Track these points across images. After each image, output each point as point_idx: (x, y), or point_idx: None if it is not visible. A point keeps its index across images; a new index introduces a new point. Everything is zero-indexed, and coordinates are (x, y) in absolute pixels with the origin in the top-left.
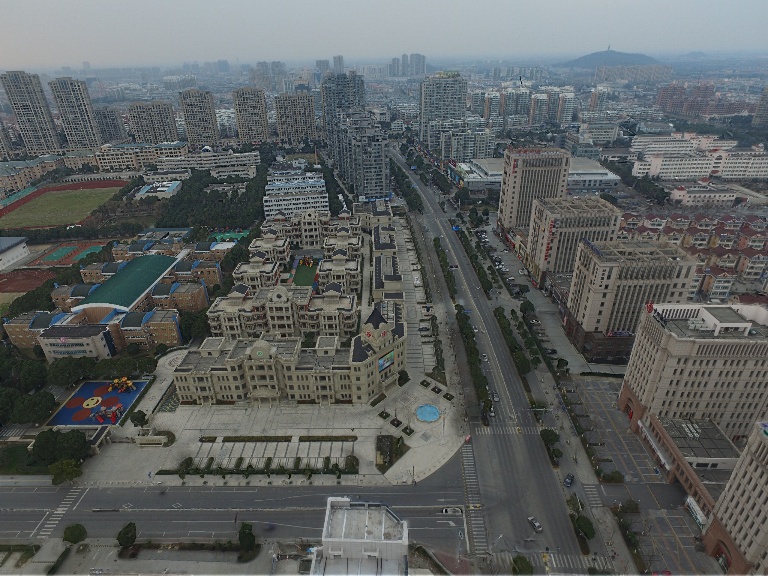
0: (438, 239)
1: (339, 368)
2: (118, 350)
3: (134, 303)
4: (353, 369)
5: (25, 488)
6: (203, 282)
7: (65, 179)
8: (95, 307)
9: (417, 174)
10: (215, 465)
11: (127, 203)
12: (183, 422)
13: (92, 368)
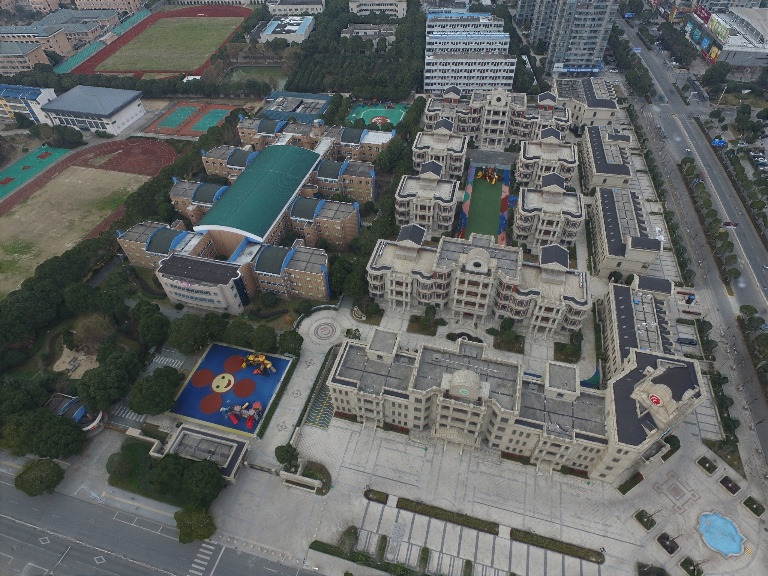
0: (692, 161)
1: (587, 437)
2: (250, 295)
3: (270, 229)
4: (615, 450)
5: (148, 522)
6: (357, 204)
7: (180, 0)
8: (222, 230)
9: (632, 26)
10: (390, 553)
11: (251, 46)
12: (340, 451)
13: (221, 332)
